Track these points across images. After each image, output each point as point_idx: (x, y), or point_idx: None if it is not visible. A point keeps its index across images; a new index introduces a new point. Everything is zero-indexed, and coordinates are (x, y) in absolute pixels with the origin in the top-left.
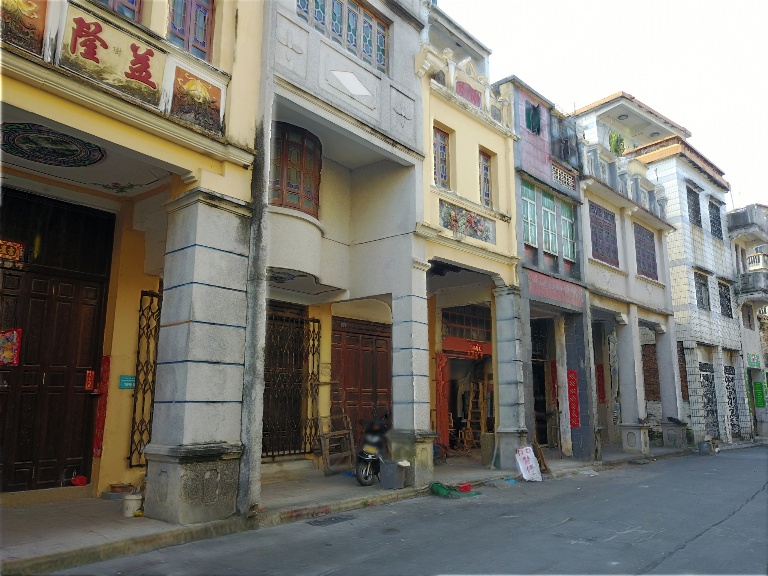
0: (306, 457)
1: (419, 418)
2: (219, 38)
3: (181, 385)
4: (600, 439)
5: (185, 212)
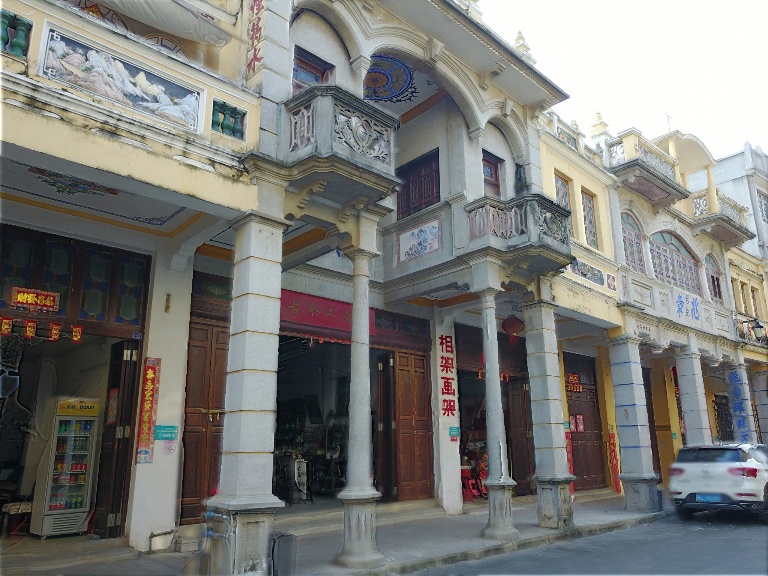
0: None
1: None
2: (760, 308)
3: None
4: None
5: (764, 377)
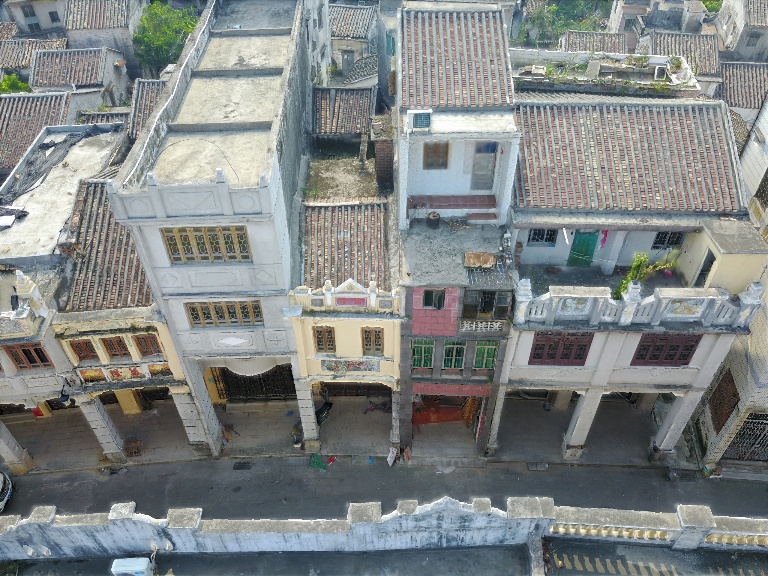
0: None
1: (308, 434)
2: None
3: None
4: None
5: None
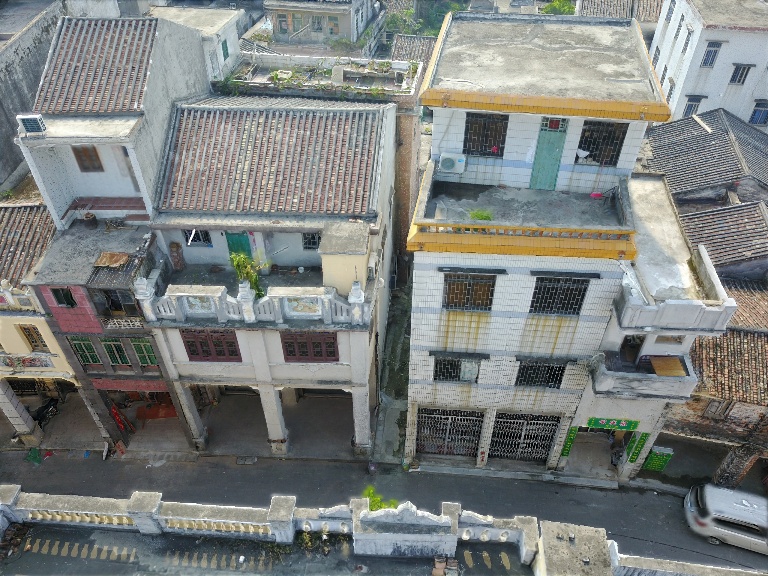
0: None
1: (19, 428)
2: None
3: None
4: (203, 443)
5: None
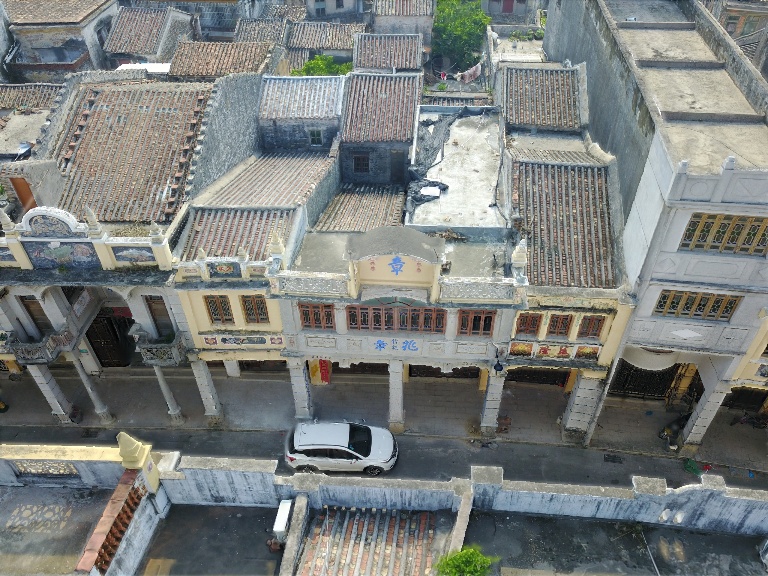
0: (664, 398)
1: (692, 437)
2: None
3: None
4: None
5: None
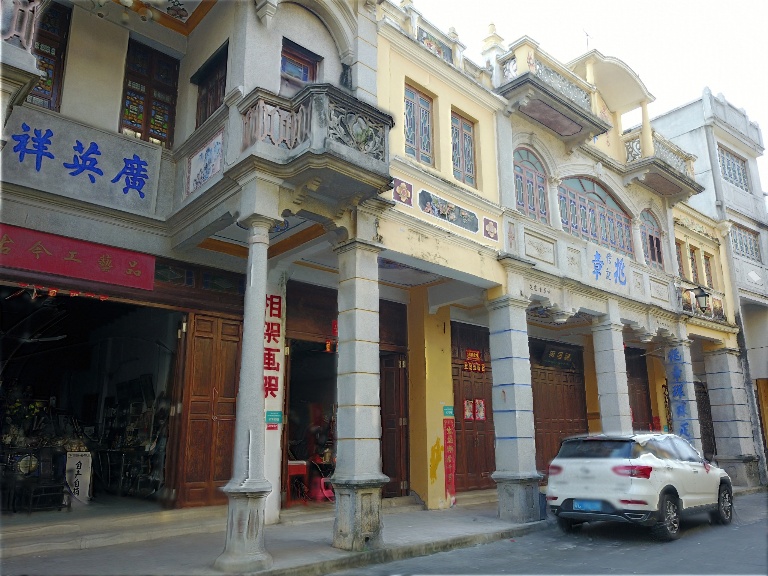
0: None
1: None
2: (716, 277)
3: (735, 431)
4: None
5: (718, 357)
